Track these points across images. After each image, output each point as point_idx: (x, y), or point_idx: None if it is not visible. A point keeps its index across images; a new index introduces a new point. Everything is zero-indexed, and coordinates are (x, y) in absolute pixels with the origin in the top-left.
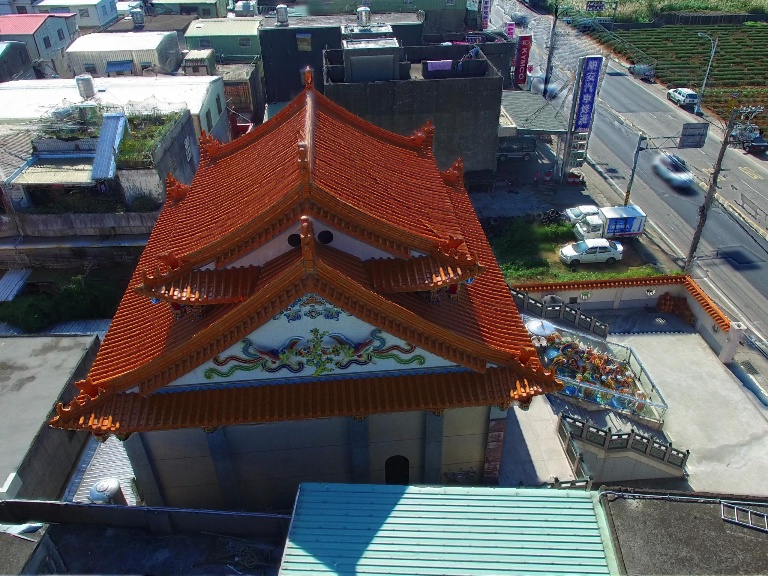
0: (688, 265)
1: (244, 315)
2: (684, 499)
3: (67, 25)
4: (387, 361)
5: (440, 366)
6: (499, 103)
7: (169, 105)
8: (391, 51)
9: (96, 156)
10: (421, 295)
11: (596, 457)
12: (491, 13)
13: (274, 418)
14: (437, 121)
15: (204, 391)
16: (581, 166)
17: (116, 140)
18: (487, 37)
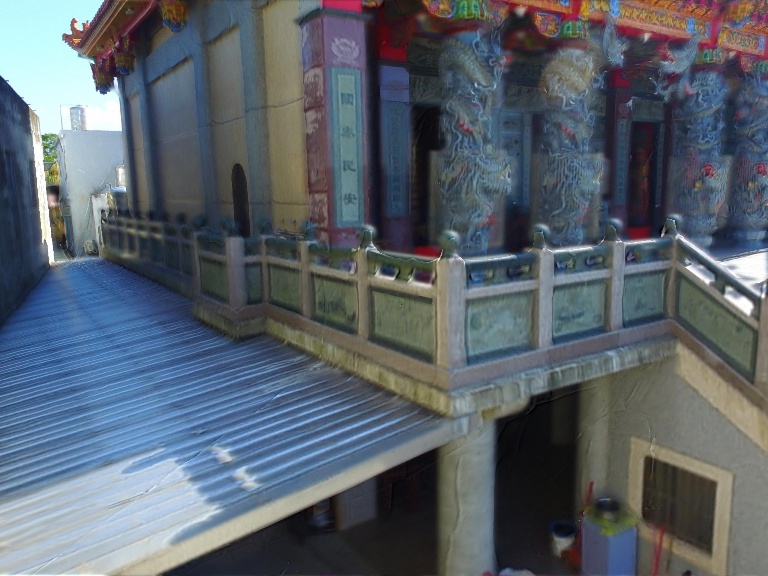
0: None
1: None
2: None
3: None
4: None
5: None
6: None
7: None
8: None
9: None
10: None
11: None
12: None
13: None
14: None
15: None
16: None
17: None
18: None
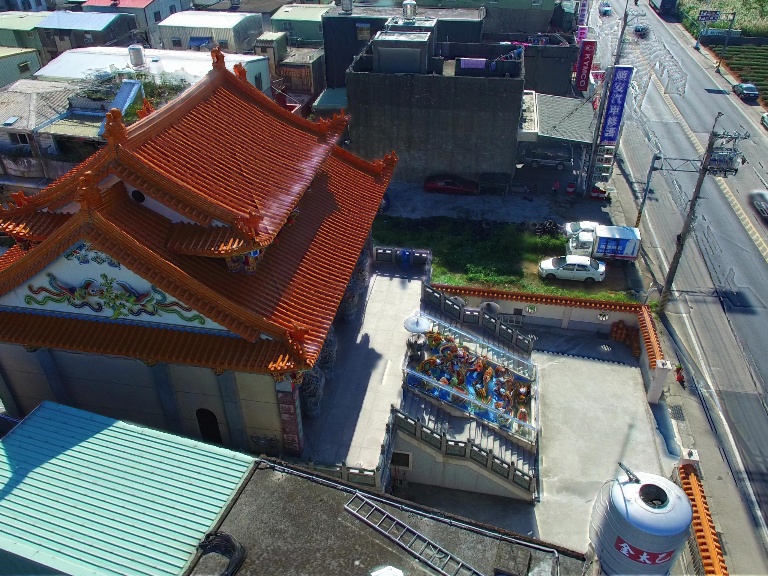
0: (663, 297)
1: (44, 252)
2: (325, 482)
3: (181, 2)
4: (172, 315)
5: (220, 329)
6: (519, 106)
7: (195, 78)
8: (418, 45)
9: None
10: (225, 263)
11: (435, 459)
12: (592, 16)
13: (66, 346)
14: (454, 118)
15: (26, 314)
16: (606, 181)
17: (126, 103)
18: (554, 40)
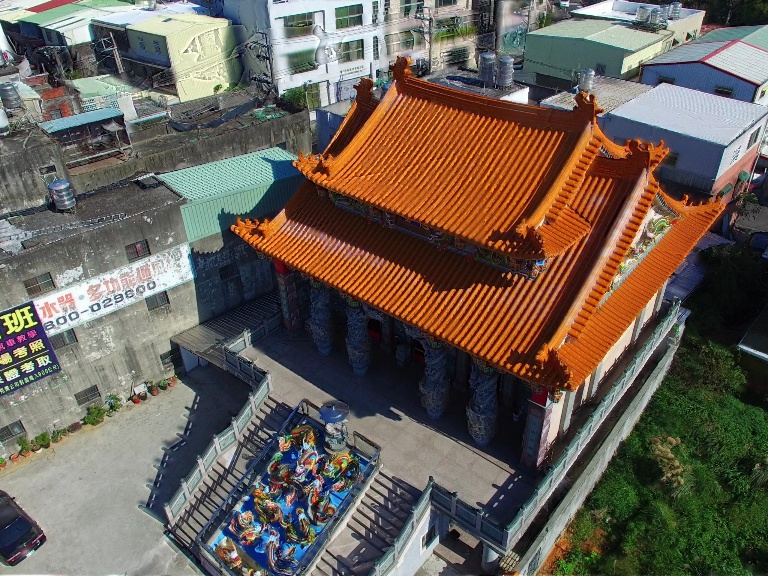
0: None
1: None
2: None
3: None
4: None
5: None
6: None
7: None
8: None
9: None
10: None
11: None
12: None
13: None
14: None
15: None
16: None
17: None
18: None
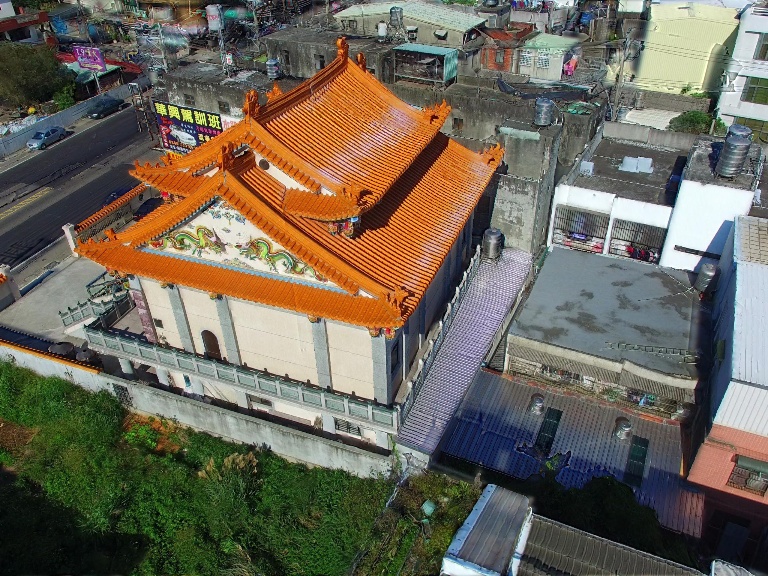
0: None
1: None
2: None
3: None
4: None
5: None
6: None
7: None
8: None
9: (520, 520)
10: None
11: None
12: None
13: None
14: None
15: None
16: None
17: (475, 523)
18: None
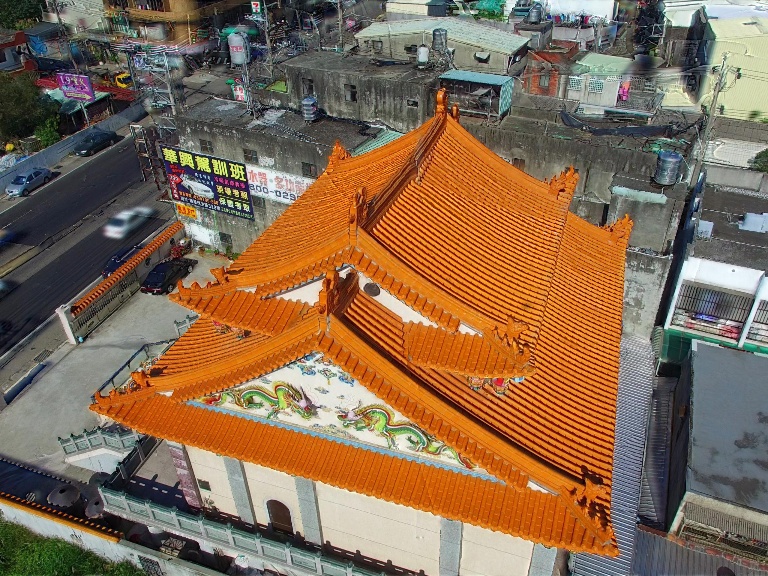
0: None
1: None
2: None
3: None
4: None
5: None
6: None
7: None
8: None
9: None
10: None
11: None
12: None
13: None
14: None
15: None
16: None
17: None
18: None
